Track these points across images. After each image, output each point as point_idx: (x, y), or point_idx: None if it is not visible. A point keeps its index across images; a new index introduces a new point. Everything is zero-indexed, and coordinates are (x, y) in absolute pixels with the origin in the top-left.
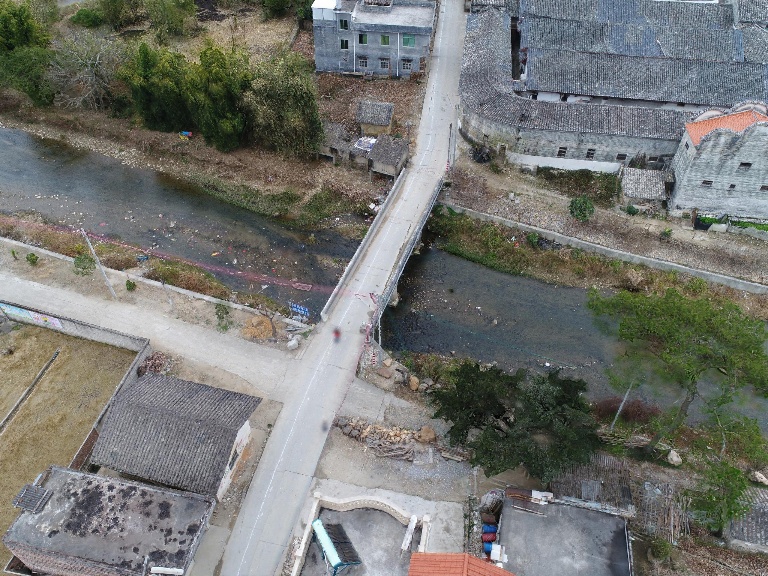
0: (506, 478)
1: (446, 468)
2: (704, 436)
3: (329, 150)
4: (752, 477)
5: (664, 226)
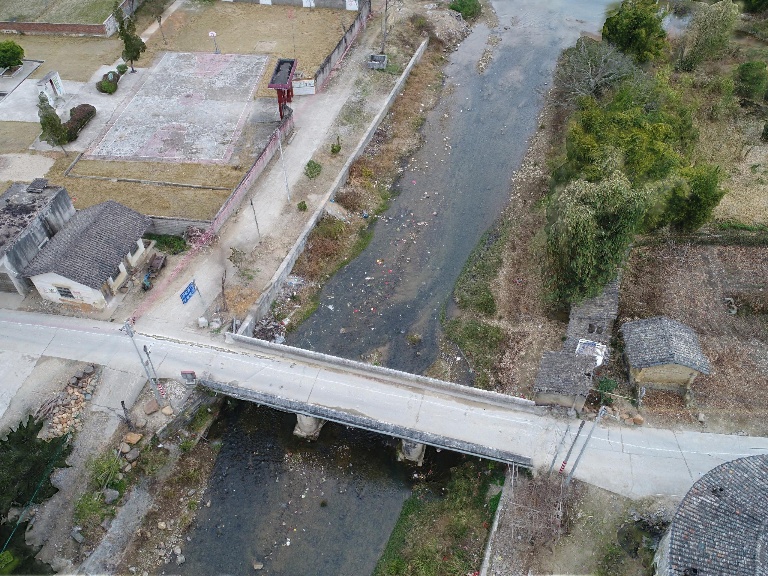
0: None
1: None
2: None
3: None
4: None
5: None
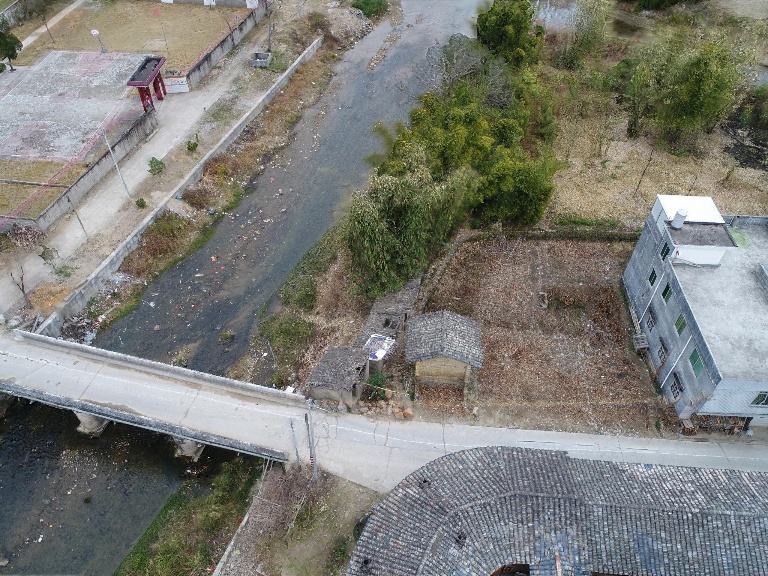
0: None
1: None
2: None
3: None
4: None
5: None
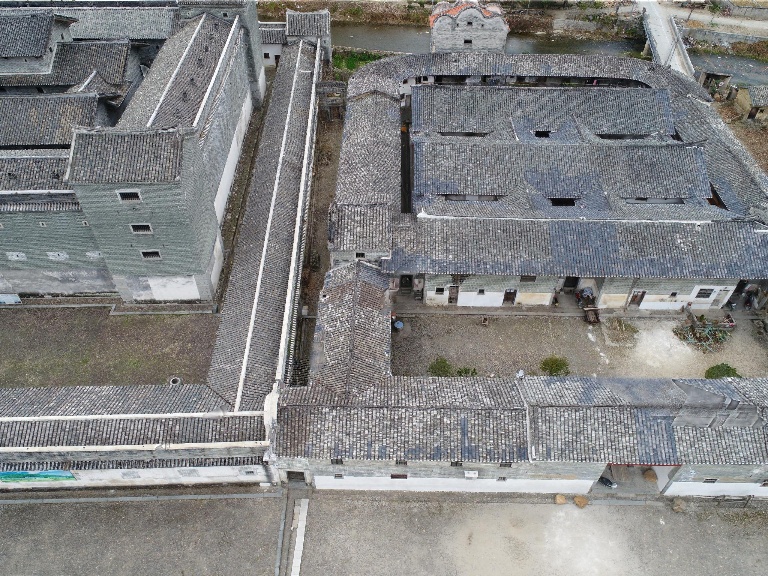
0: None
1: None
2: None
3: None
4: None
5: None
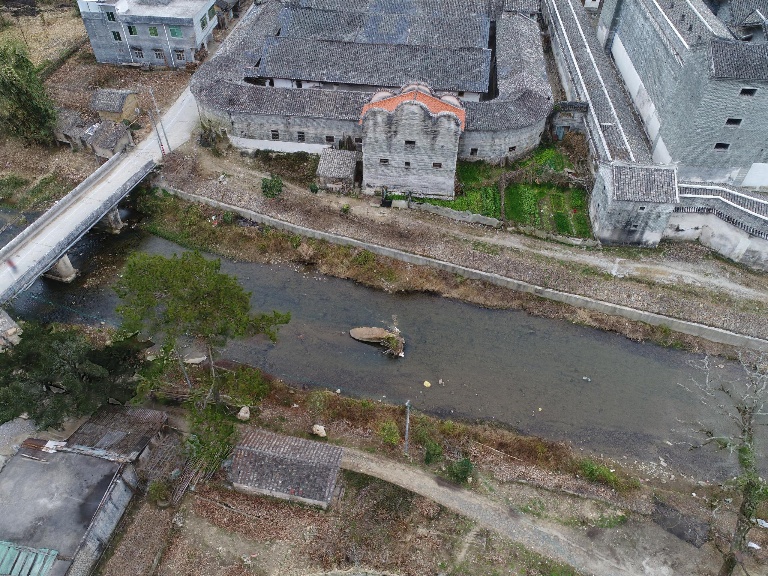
0: (66, 433)
1: (10, 425)
2: (298, 395)
3: (64, 136)
4: (310, 430)
5: (353, 203)
